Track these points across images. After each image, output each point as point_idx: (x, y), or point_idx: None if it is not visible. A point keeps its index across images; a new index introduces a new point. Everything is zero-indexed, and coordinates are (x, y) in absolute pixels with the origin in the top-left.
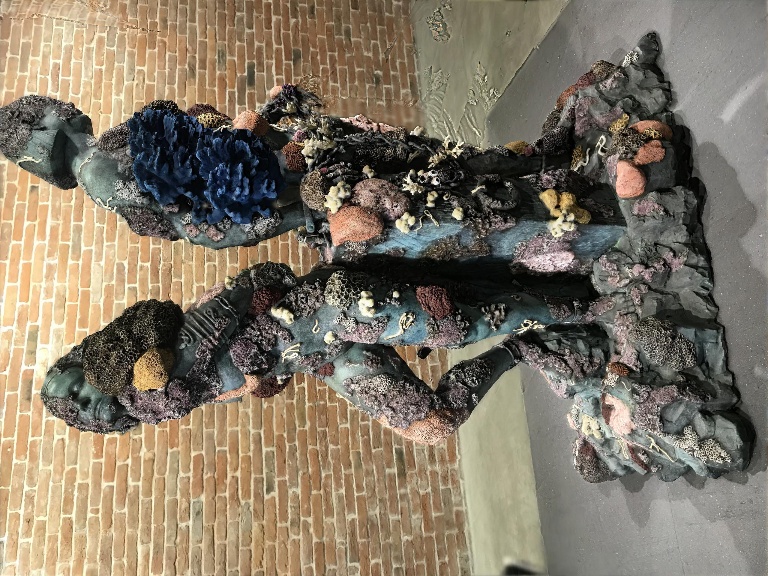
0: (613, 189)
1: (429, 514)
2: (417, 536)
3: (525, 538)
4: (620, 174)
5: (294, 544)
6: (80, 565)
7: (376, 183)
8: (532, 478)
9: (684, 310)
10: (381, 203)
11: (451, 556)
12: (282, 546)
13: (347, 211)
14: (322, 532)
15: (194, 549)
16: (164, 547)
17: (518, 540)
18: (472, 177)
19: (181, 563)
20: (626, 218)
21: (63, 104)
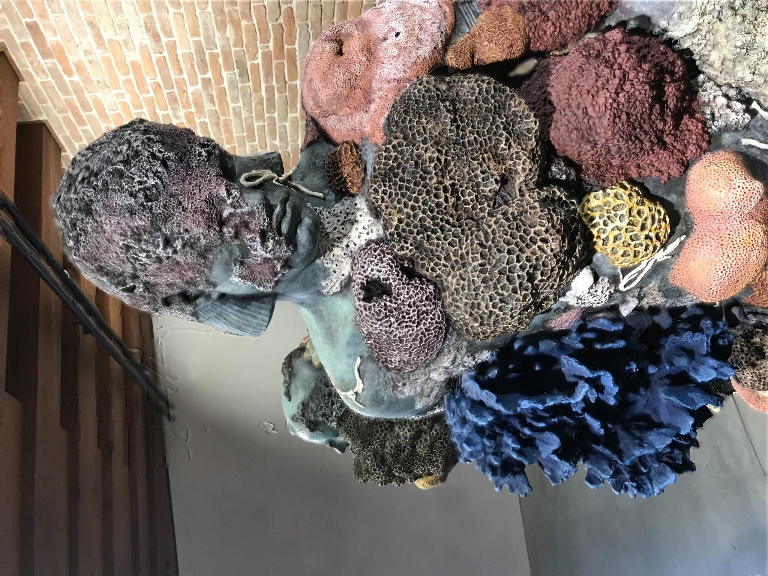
0: None
1: None
2: None
3: None
4: None
5: None
6: None
7: None
8: None
9: None
10: None
11: None
12: None
13: None
14: None
15: None
16: None
17: None
18: None
19: None
20: None
21: (238, 214)
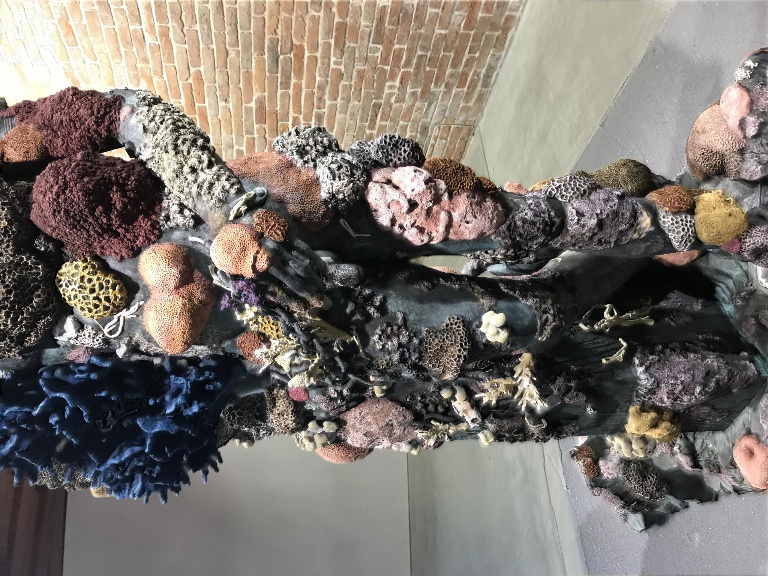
0: (762, 392)
1: (475, 13)
2: (453, 31)
3: (543, 145)
4: (745, 471)
5: (313, 19)
6: (76, 9)
7: (379, 422)
8: (576, 128)
9: (700, 473)
10: (377, 442)
11: (483, 52)
12: (299, 20)
13: (324, 451)
14: (346, 14)
15: (201, 7)
16: (166, 1)
17: (539, 132)
18: (546, 385)
19: (188, 18)
20: (732, 426)
21: None
